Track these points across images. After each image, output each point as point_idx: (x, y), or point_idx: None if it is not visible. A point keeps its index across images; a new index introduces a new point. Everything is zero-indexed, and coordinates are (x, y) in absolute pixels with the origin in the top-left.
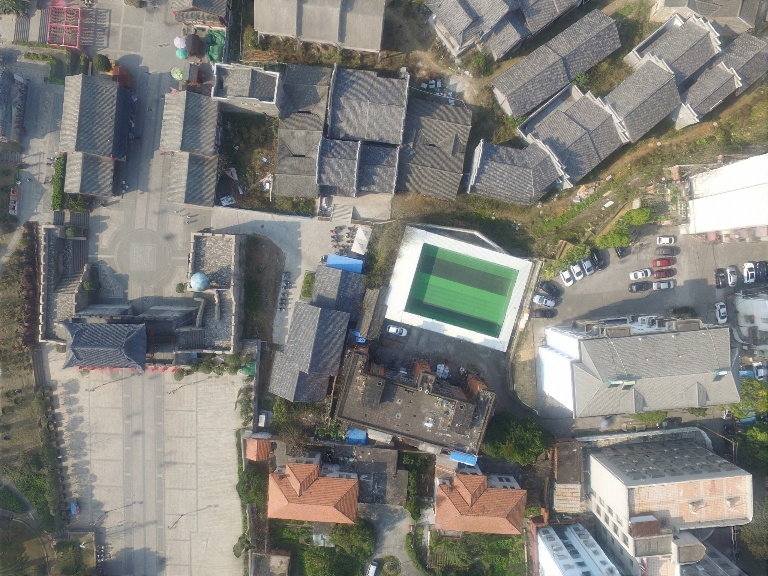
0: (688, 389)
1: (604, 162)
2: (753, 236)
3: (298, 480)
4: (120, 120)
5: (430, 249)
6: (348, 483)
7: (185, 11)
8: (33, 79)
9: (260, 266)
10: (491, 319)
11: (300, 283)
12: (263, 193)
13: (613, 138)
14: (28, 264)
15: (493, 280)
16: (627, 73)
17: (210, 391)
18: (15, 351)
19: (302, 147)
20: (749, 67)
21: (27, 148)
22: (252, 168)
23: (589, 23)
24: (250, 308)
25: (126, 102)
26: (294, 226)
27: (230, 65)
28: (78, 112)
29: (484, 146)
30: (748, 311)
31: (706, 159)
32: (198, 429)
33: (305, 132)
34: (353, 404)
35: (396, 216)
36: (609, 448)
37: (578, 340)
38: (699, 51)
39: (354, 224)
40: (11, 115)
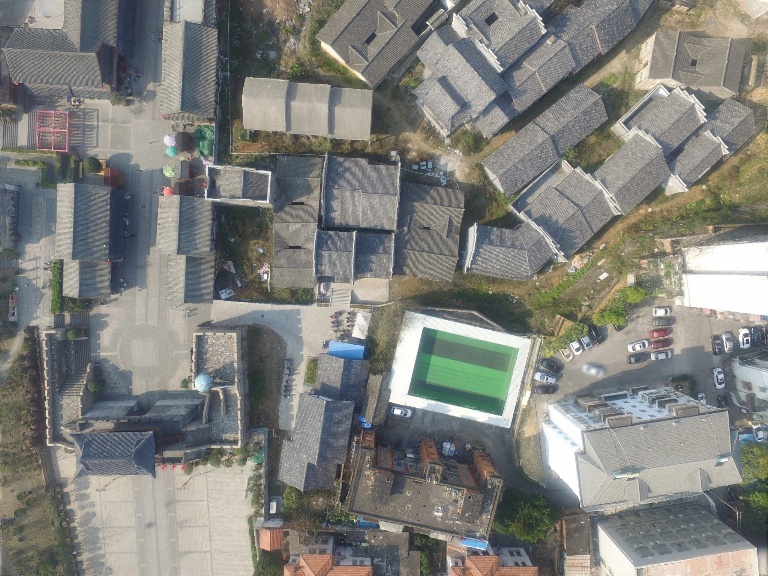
0: (691, 475)
1: (597, 232)
2: (747, 319)
3: (313, 572)
4: (114, 222)
5: (430, 330)
6: (362, 571)
7: (173, 114)
8: (25, 185)
9: (262, 355)
10: (494, 395)
11: (303, 369)
12: (261, 284)
13: (605, 211)
14: (31, 368)
15: (494, 357)
16: (615, 142)
17: (220, 480)
18: (23, 454)
19: (298, 239)
20: (735, 133)
21: (23, 254)
22: (249, 260)
23: (575, 99)
24: (255, 398)
25: (119, 203)
26: (294, 314)
27: (222, 166)
28: (72, 221)
29: (478, 229)
30: (745, 377)
31: (697, 229)
32: (210, 518)
33: (300, 225)
34: (363, 498)
35: (394, 297)
36: (616, 516)
37: (581, 432)
38: (685, 122)
39: (353, 308)
40: (5, 225)
